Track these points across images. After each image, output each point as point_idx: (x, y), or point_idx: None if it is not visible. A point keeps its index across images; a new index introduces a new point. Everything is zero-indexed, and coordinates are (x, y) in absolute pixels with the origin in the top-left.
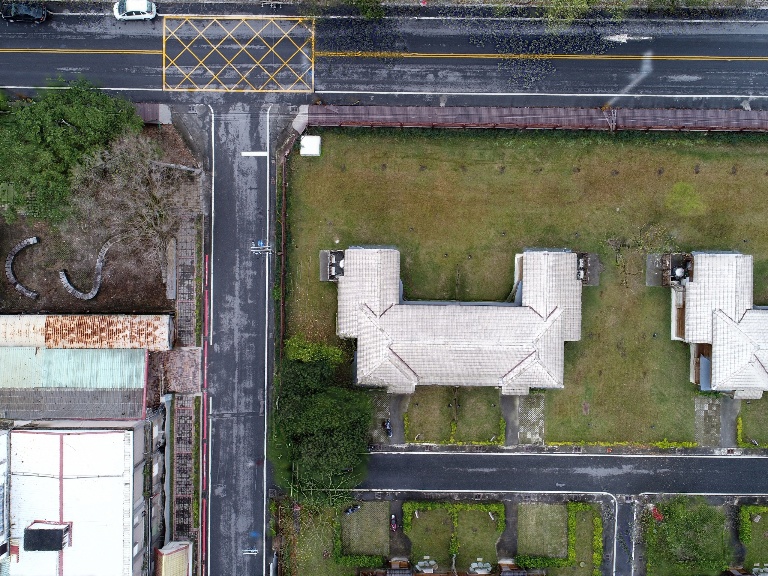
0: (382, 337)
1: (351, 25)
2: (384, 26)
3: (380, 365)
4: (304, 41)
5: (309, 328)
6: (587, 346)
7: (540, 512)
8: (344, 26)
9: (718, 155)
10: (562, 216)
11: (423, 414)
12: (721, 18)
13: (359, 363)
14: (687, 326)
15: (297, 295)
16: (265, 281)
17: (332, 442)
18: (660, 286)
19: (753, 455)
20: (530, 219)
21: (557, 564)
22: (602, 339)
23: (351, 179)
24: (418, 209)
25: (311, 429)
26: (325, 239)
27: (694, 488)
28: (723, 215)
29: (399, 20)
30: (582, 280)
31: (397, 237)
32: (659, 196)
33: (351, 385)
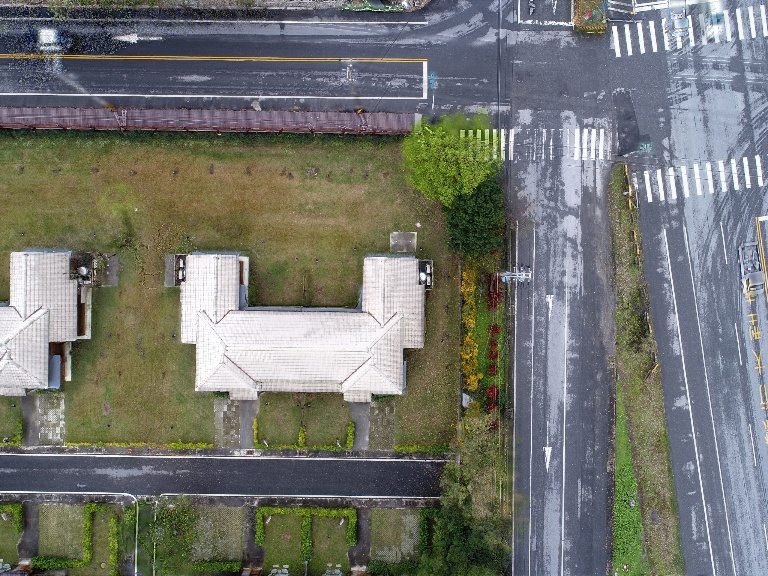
0: None
1: None
2: None
3: None
4: None
5: None
6: (107, 347)
7: (61, 513)
8: None
9: (232, 155)
10: (81, 216)
11: None
12: (231, 18)
13: None
14: (181, 327)
15: None
16: None
17: None
18: None
19: (272, 456)
20: (49, 219)
21: (71, 565)
22: (122, 340)
23: None
24: None
25: None
26: None
27: (214, 489)
28: (242, 216)
29: None
30: (91, 280)
31: None
32: (177, 196)
33: None
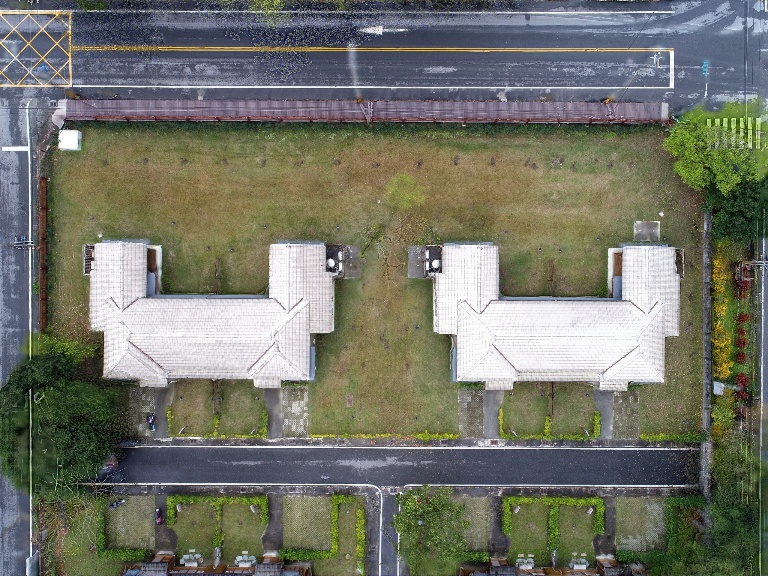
0: (123, 330)
1: (108, 19)
2: (140, 20)
3: (122, 358)
4: (61, 35)
5: (73, 322)
6: (350, 338)
7: (305, 505)
8: (101, 20)
9: (476, 146)
10: (324, 209)
11: (188, 408)
12: (477, 9)
13: (105, 357)
14: (437, 317)
15: (61, 290)
16: (28, 276)
17: (96, 436)
18: (422, 278)
19: (516, 446)
20: (292, 212)
21: (319, 556)
22: (365, 331)
23: (113, 173)
24: (180, 203)
25: (75, 423)
26: (88, 233)
27: (458, 479)
28: (484, 206)
29: (156, 14)
30: (339, 272)
31: (160, 231)
32: (420, 188)
33: (98, 379)
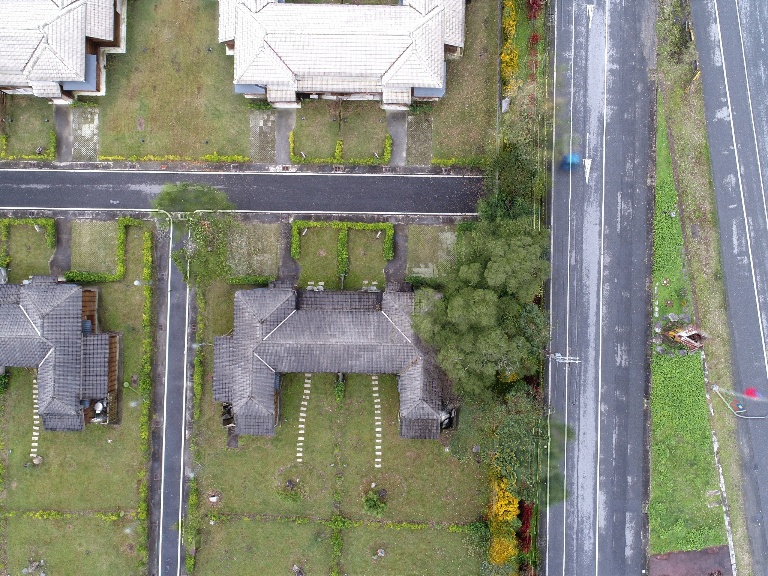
0: None
1: None
2: None
3: None
4: None
5: None
6: (141, 61)
7: (94, 229)
8: None
9: None
10: None
11: None
12: None
13: None
14: (219, 26)
15: None
16: None
17: None
18: None
19: (308, 172)
20: None
21: (104, 278)
22: (157, 54)
23: None
24: None
25: None
26: None
27: (249, 205)
28: None
29: None
30: None
31: None
32: None
33: None
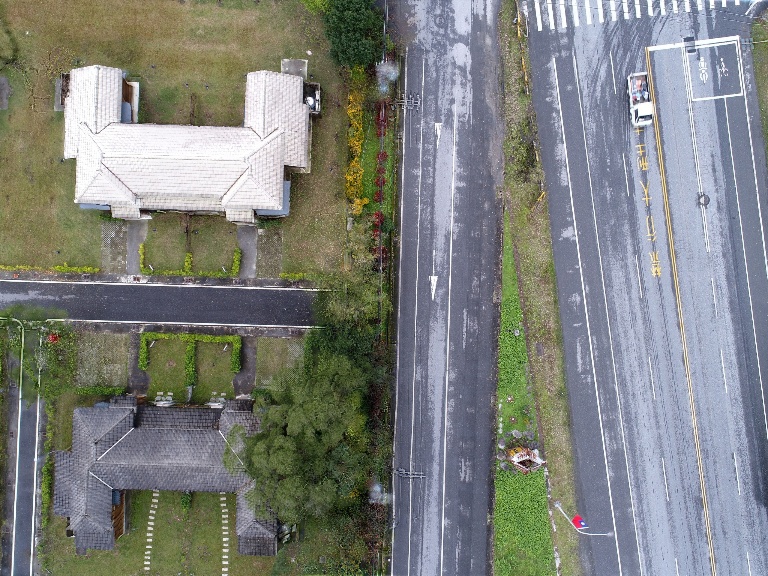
0: None
1: None
2: None
3: None
4: None
5: None
6: None
7: None
8: None
9: None
10: None
11: None
12: None
13: None
14: None
15: None
16: None
17: None
18: None
19: (159, 283)
20: None
21: None
22: (10, 163)
23: None
24: None
25: None
26: None
27: (99, 315)
28: (133, 41)
29: None
30: None
31: None
32: (68, 20)
33: None
